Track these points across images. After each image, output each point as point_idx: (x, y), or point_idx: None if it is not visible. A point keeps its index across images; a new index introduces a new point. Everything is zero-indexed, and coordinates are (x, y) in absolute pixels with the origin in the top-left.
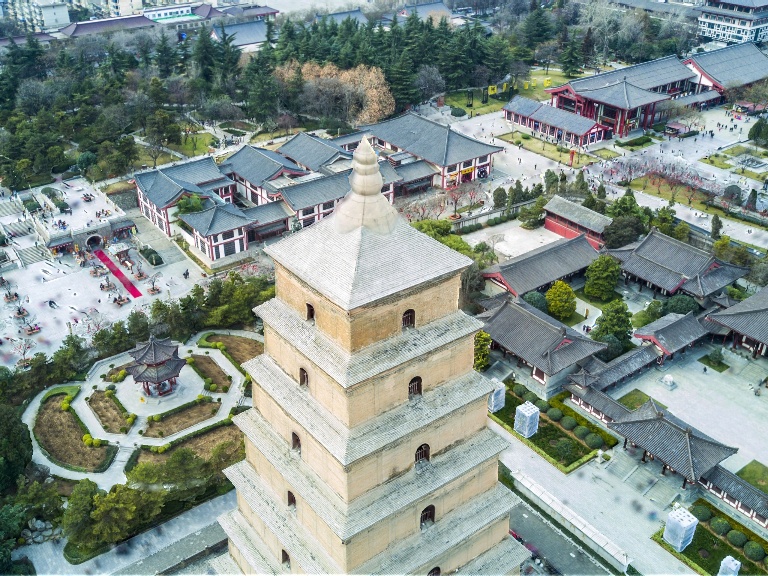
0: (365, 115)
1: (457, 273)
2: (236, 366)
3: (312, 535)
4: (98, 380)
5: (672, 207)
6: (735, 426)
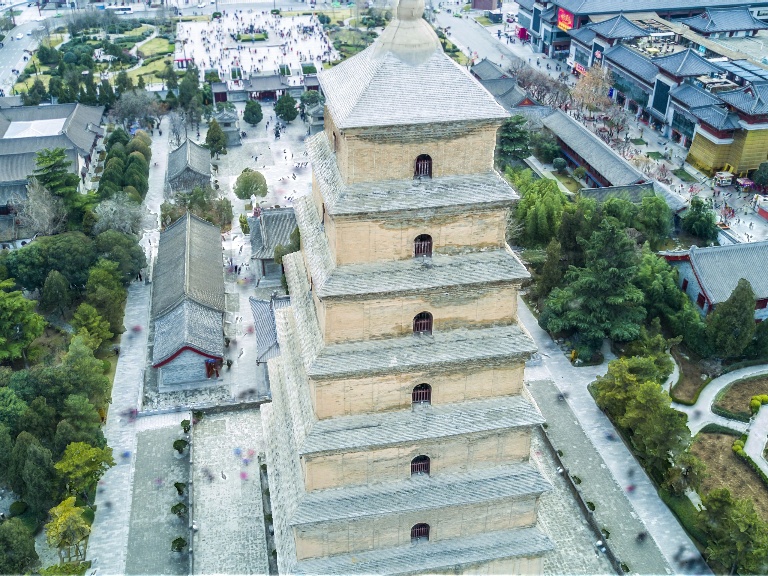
0: None
1: None
2: None
3: None
4: None
5: None
6: None
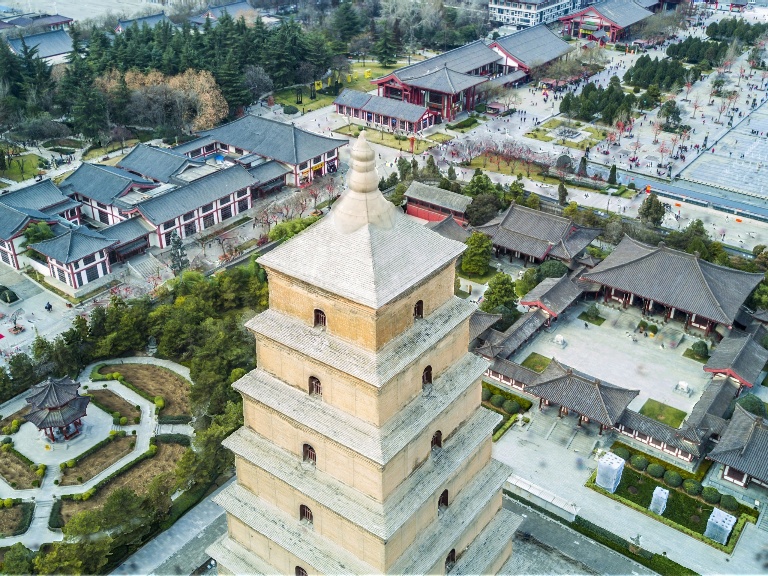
0: (201, 120)
1: (454, 259)
2: (141, 395)
3: (336, 544)
4: None
5: (520, 181)
6: (625, 371)
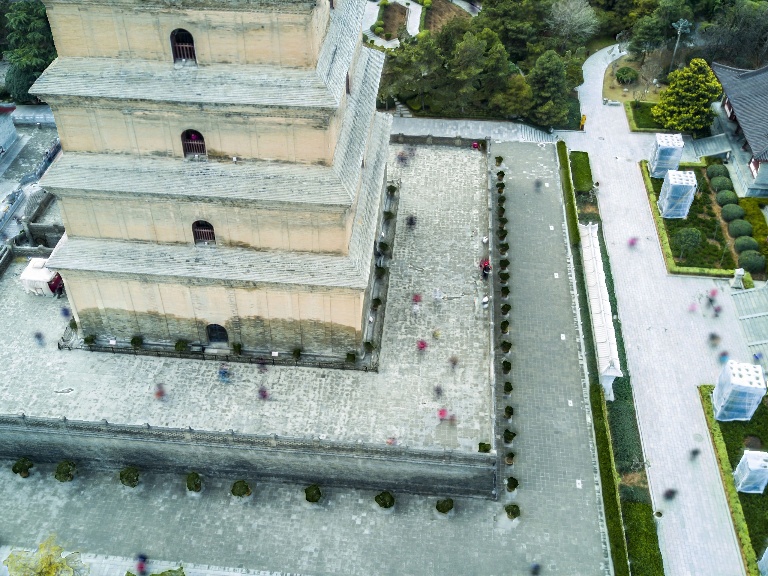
0: None
1: None
2: (420, 23)
3: None
4: None
5: None
6: None
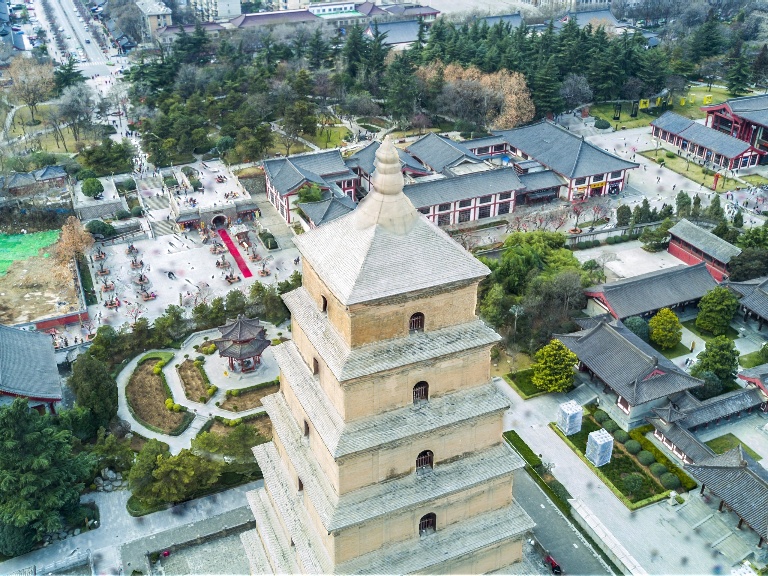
0: (501, 120)
1: (473, 282)
2: None
3: (313, 522)
4: (191, 350)
5: None
6: None
